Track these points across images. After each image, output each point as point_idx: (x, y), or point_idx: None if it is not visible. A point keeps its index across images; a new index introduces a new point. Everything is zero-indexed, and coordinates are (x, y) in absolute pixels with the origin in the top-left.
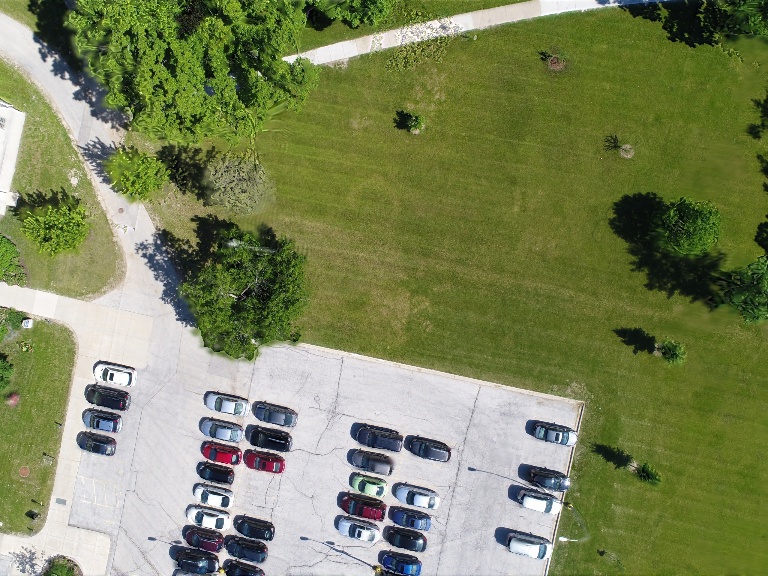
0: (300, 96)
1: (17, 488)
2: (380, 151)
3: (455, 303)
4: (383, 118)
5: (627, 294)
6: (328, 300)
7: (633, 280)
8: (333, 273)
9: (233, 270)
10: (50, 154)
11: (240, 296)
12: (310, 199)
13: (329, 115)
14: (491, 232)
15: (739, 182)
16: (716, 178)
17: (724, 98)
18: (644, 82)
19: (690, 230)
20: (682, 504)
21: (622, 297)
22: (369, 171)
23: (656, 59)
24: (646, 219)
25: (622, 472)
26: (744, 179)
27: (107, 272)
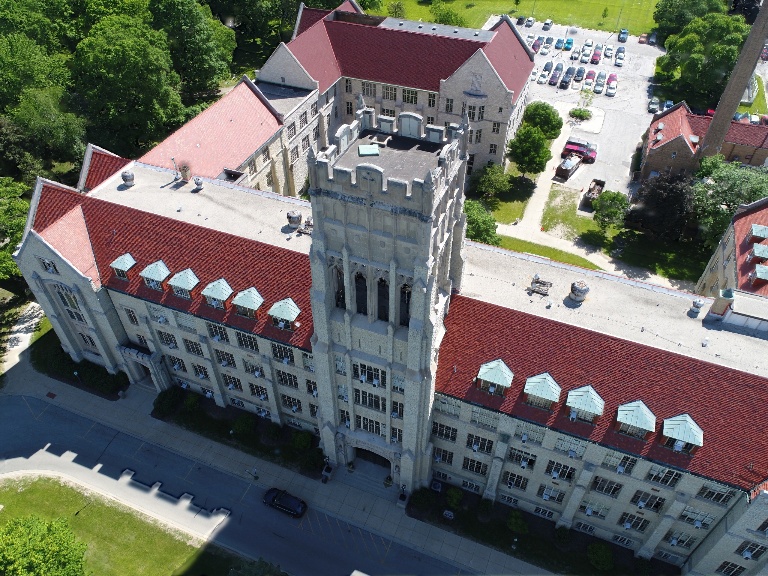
0: None
1: None
2: None
3: None
4: None
5: None
6: None
7: None
8: None
9: None
10: None
11: None
12: None
13: None
14: None
15: None
16: None
17: None
18: None
19: None
20: (530, 6)
21: (454, 7)
22: None
23: None
24: None
25: None
26: None
27: None
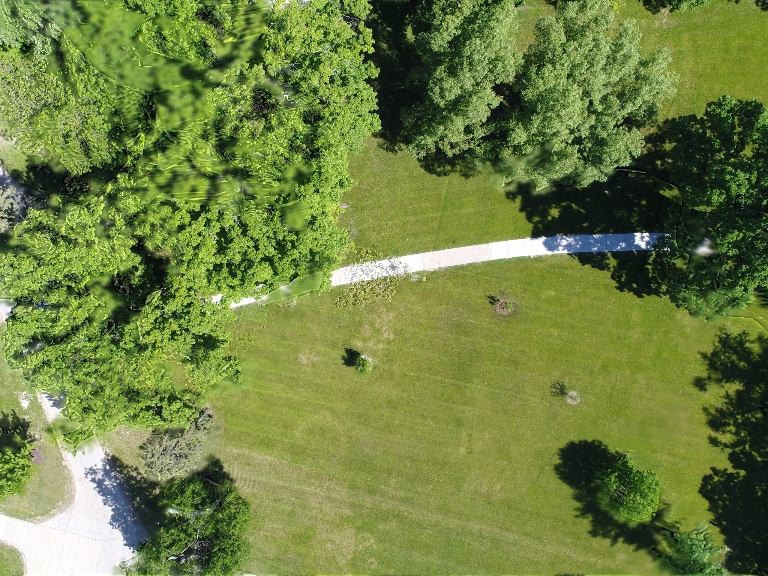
0: (248, 338)
1: None
2: (328, 387)
3: (400, 541)
4: (332, 355)
5: (571, 540)
6: (274, 532)
7: (577, 526)
8: (280, 506)
9: (173, 530)
10: (1, 376)
11: (180, 555)
12: (258, 432)
13: (278, 350)
14: (437, 472)
15: (684, 433)
16: (662, 428)
17: (671, 350)
18: (592, 330)
19: (630, 496)
20: None
21: (566, 543)
22: (317, 406)
23: (604, 308)
24: (591, 466)
25: None
26: (689, 431)
27: (56, 495)
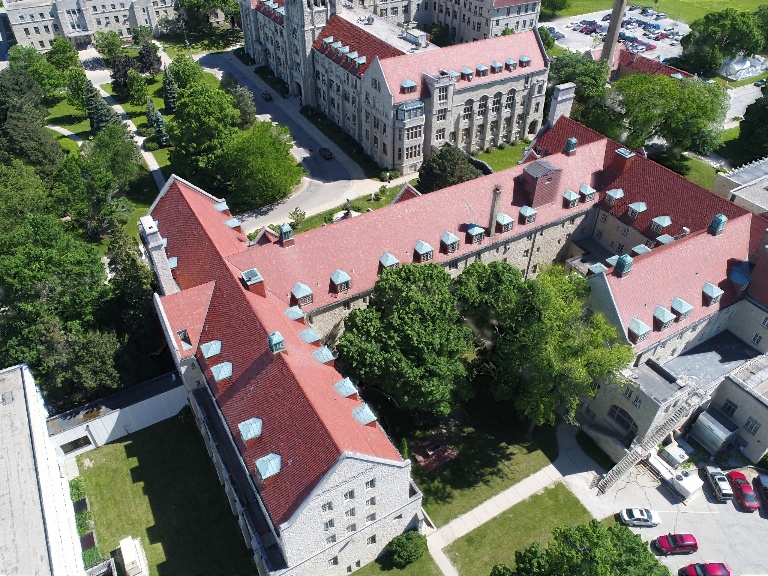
0: None
1: (555, 48)
2: None
3: None
4: None
5: None
6: None
7: None
8: None
9: None
10: None
11: None
12: None
13: None
14: None
15: None
16: None
17: None
18: None
19: None
20: None
21: None
22: None
23: None
24: None
25: (654, 8)
26: None
27: None
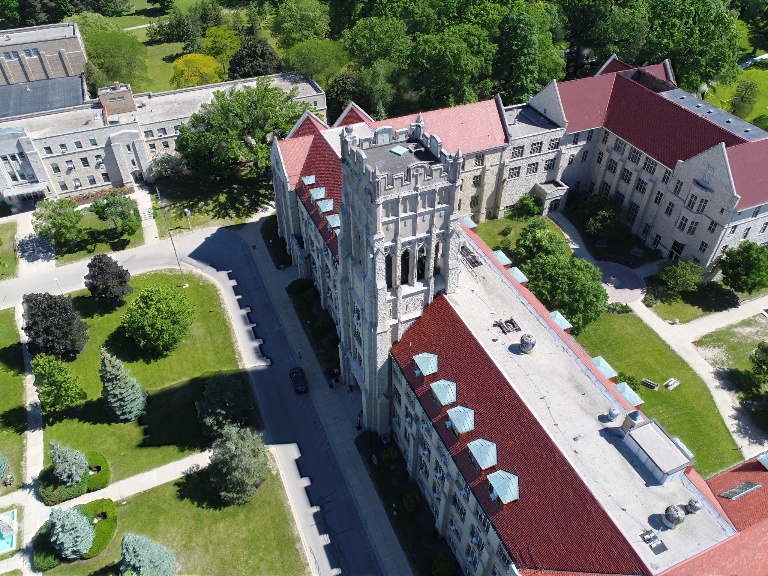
0: None
1: None
2: None
3: None
4: None
5: None
6: None
7: None
8: None
9: None
10: None
11: None
12: None
13: None
14: None
15: None
16: None
17: None
18: None
19: None
20: None
21: None
22: None
23: None
24: None
25: None
26: None
27: None
